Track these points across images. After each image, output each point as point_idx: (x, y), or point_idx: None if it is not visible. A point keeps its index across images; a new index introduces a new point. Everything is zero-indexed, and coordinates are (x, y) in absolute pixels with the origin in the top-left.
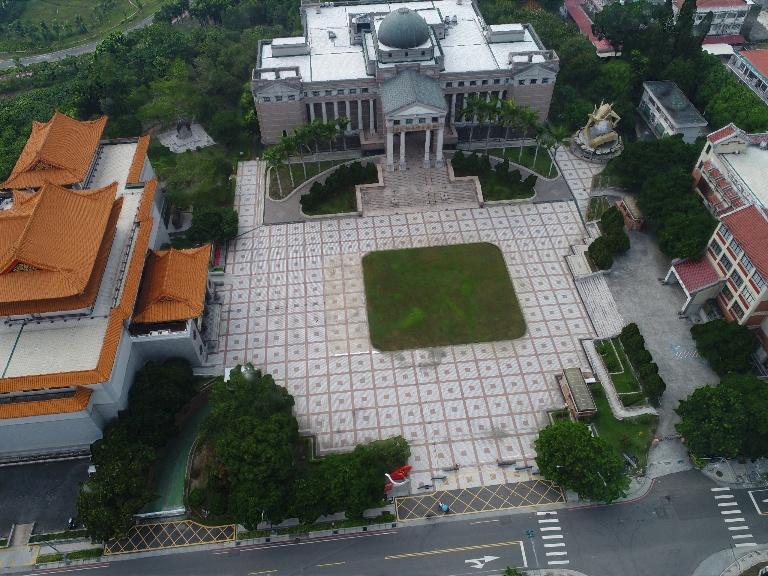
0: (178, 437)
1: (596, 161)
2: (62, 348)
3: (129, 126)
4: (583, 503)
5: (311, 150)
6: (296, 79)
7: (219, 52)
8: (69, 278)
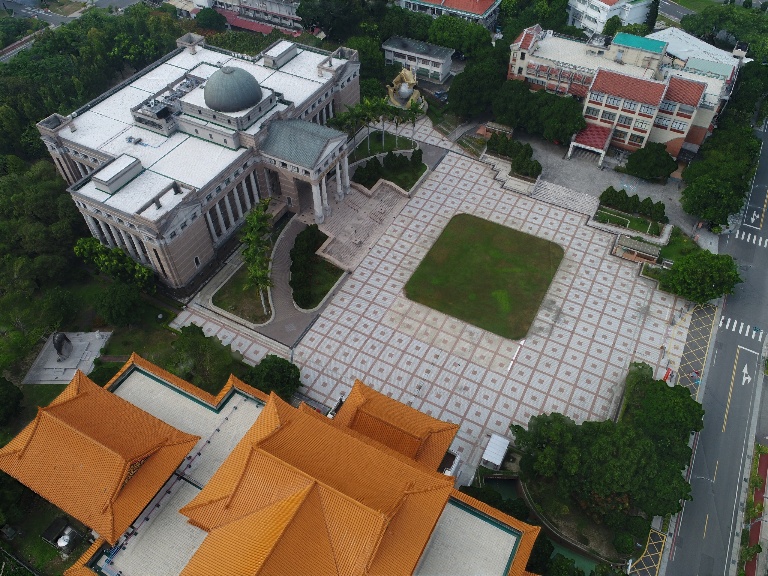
0: None
1: (420, 117)
2: (460, 564)
3: (4, 392)
4: (722, 299)
5: (219, 261)
6: (192, 193)
7: None
8: None
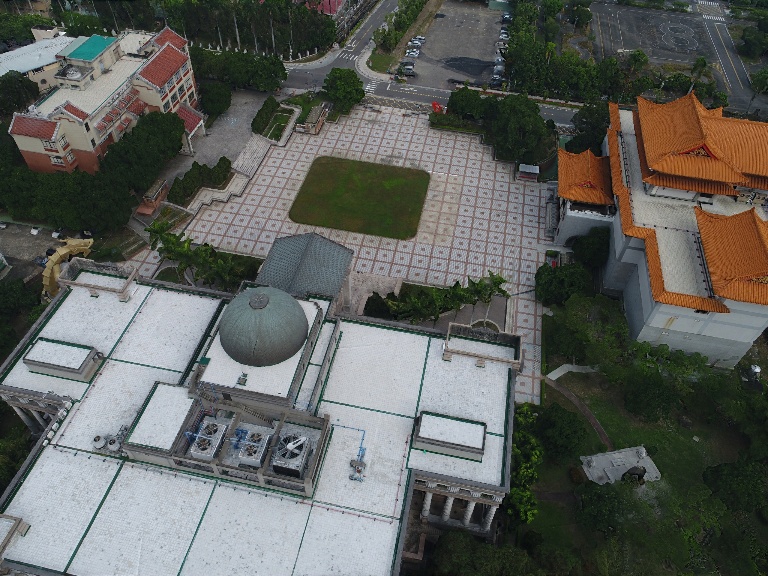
0: None
1: None
2: None
3: (725, 468)
4: None
5: None
6: (455, 326)
7: None
8: (651, 103)
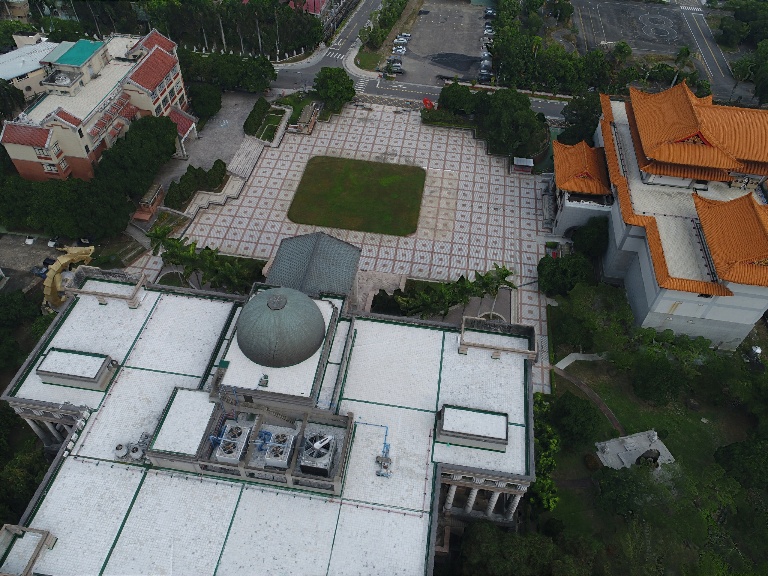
0: None
1: None
2: None
3: (736, 448)
4: None
5: None
6: (469, 319)
7: None
8: (643, 93)
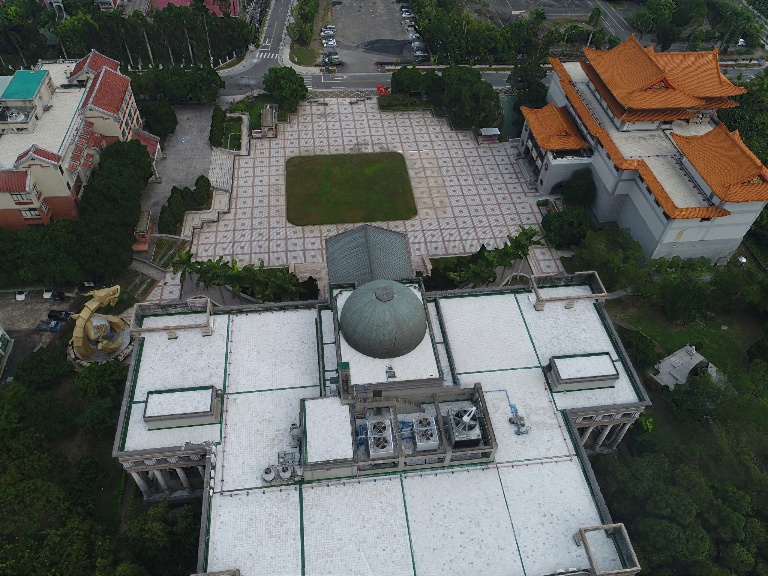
0: None
1: None
2: None
3: (766, 342)
4: None
5: None
6: (536, 278)
7: (766, 529)
8: (597, 51)
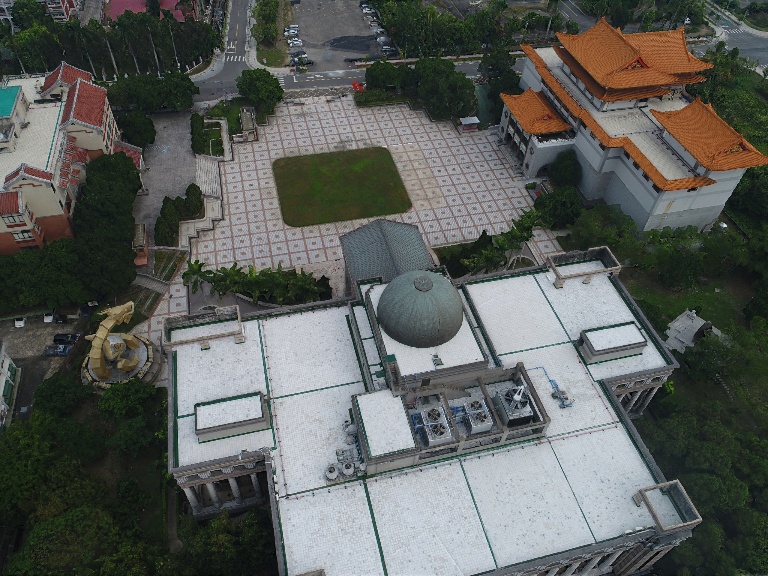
0: (493, 115)
1: None
2: None
3: (761, 300)
4: None
5: None
6: (552, 257)
7: None
8: (570, 35)
